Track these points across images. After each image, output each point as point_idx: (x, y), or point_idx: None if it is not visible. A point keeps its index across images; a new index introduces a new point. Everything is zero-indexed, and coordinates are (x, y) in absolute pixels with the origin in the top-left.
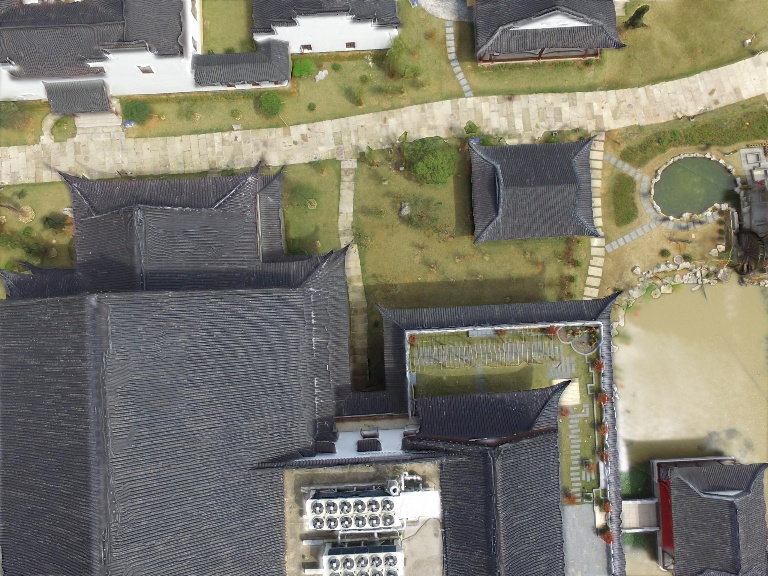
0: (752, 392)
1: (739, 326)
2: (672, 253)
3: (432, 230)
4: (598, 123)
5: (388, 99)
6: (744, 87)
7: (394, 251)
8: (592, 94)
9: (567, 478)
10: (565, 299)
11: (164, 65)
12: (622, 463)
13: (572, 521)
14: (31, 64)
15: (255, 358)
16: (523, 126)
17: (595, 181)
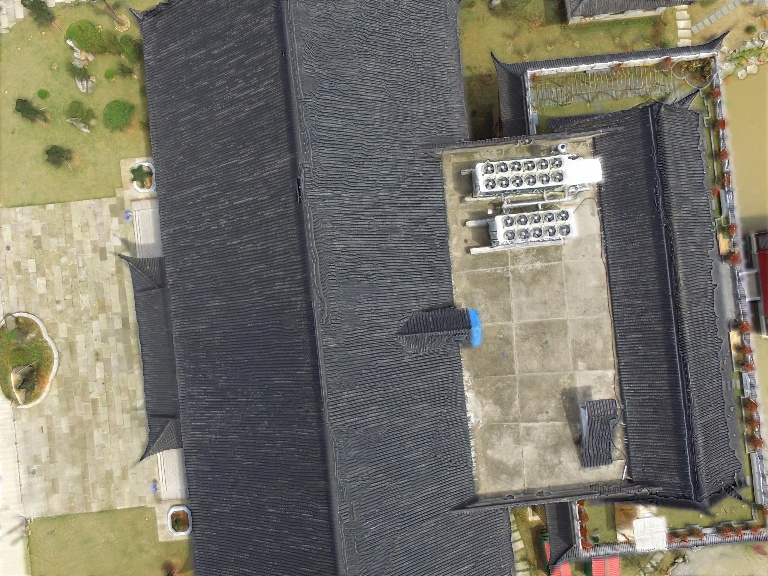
0: None
1: None
2: (757, 30)
3: (522, 21)
4: None
5: None
6: None
7: (486, 43)
8: None
9: None
10: None
11: None
12: None
13: None
14: None
15: (409, 47)
16: None
17: None
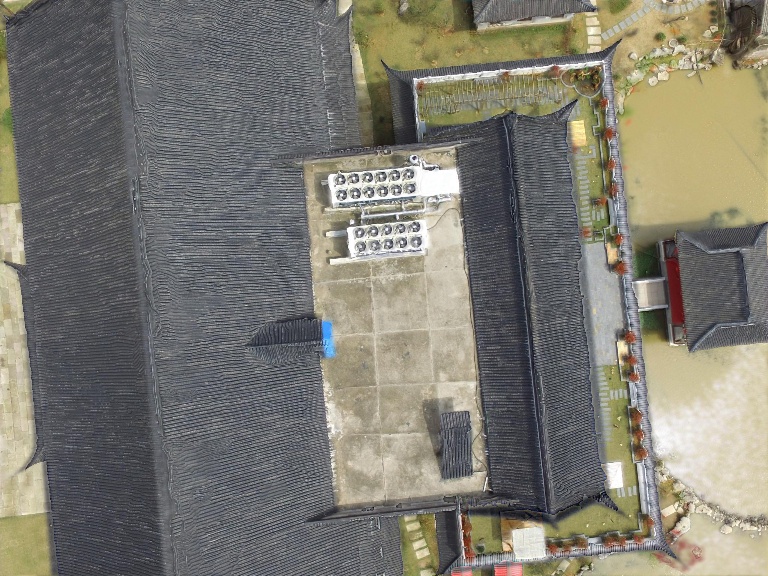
0: (751, 174)
1: (735, 114)
2: (667, 36)
3: (431, 27)
4: None
5: None
6: None
7: (395, 48)
8: None
9: (578, 218)
10: None
11: None
12: None
13: (585, 260)
14: None
15: (269, 56)
16: None
17: None
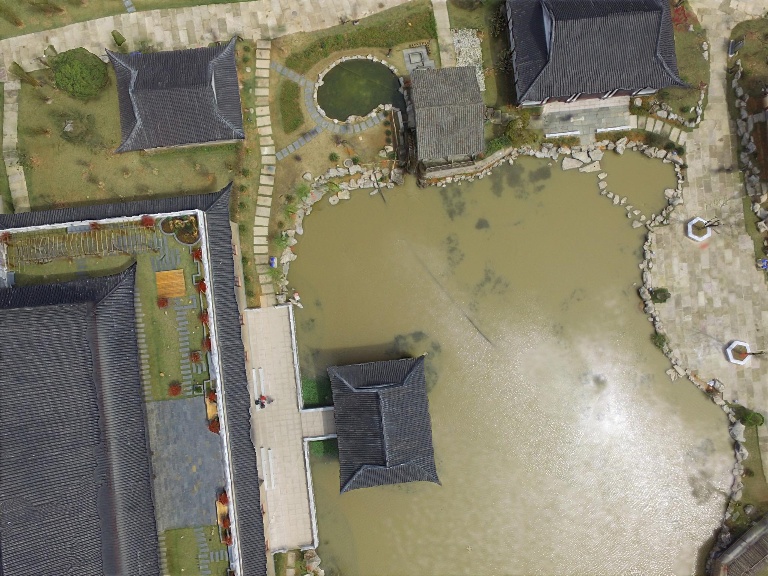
0: (437, 293)
1: (427, 230)
2: (341, 157)
3: (99, 147)
4: (263, 32)
5: (49, 18)
6: None
7: (60, 170)
8: (256, 3)
9: (177, 371)
10: (238, 209)
11: None
12: (308, 372)
13: (184, 415)
14: None
15: None
16: (188, 39)
17: (262, 90)
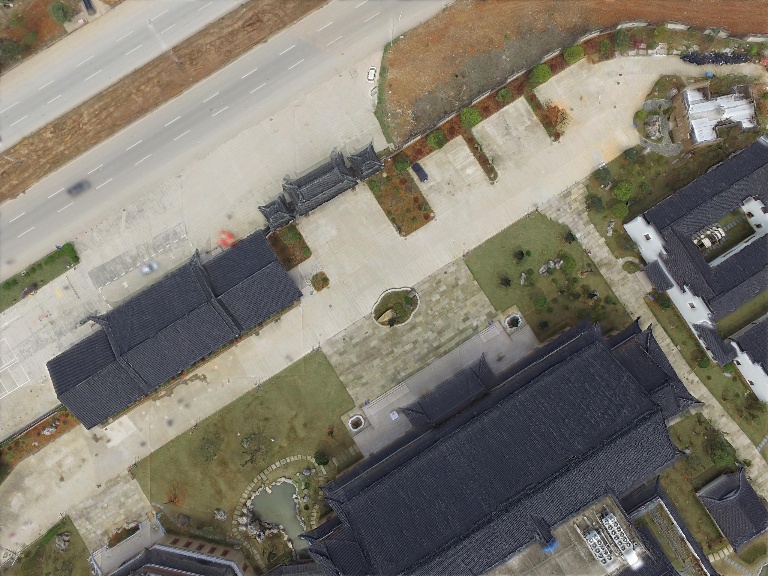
0: None
1: None
2: None
3: (685, 468)
4: None
5: (734, 411)
6: None
7: None
8: None
9: None
10: None
11: (700, 315)
12: None
13: None
14: (670, 261)
15: None
16: (759, 483)
17: None
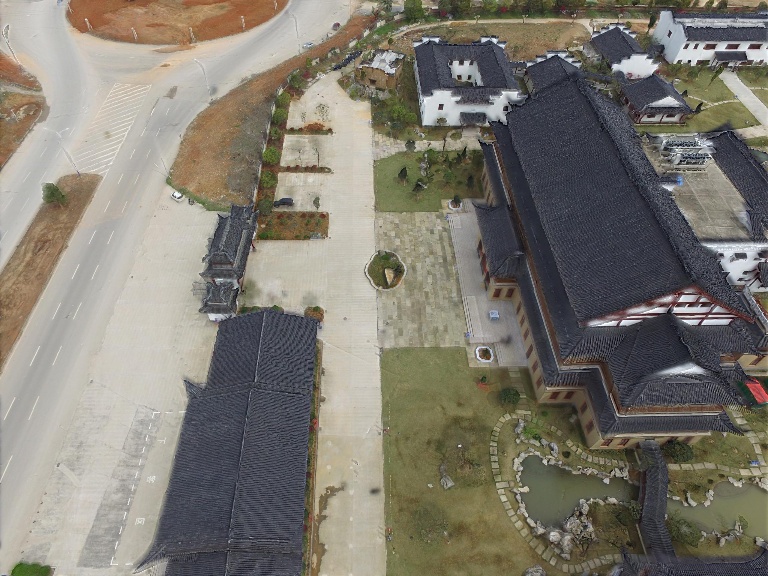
0: None
1: None
2: None
3: None
4: None
5: None
6: (754, 134)
7: None
8: (688, 134)
9: None
10: None
11: None
12: None
13: None
14: (466, 100)
15: None
16: None
17: None
